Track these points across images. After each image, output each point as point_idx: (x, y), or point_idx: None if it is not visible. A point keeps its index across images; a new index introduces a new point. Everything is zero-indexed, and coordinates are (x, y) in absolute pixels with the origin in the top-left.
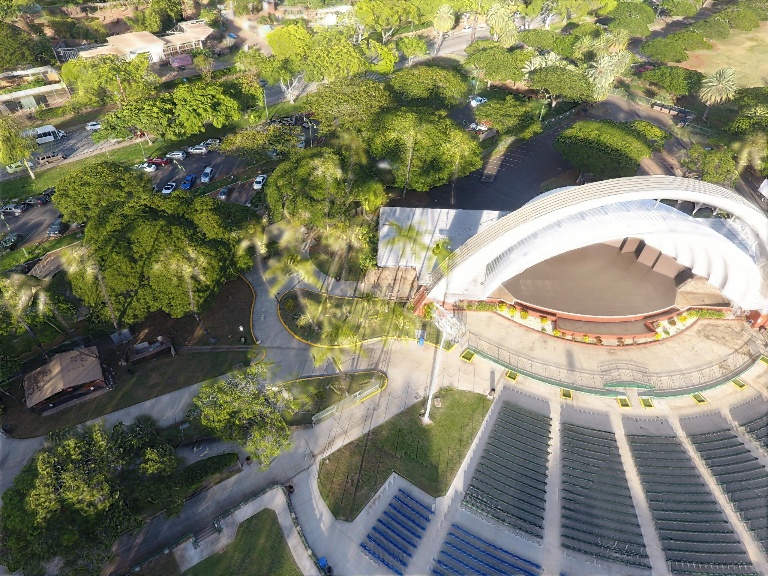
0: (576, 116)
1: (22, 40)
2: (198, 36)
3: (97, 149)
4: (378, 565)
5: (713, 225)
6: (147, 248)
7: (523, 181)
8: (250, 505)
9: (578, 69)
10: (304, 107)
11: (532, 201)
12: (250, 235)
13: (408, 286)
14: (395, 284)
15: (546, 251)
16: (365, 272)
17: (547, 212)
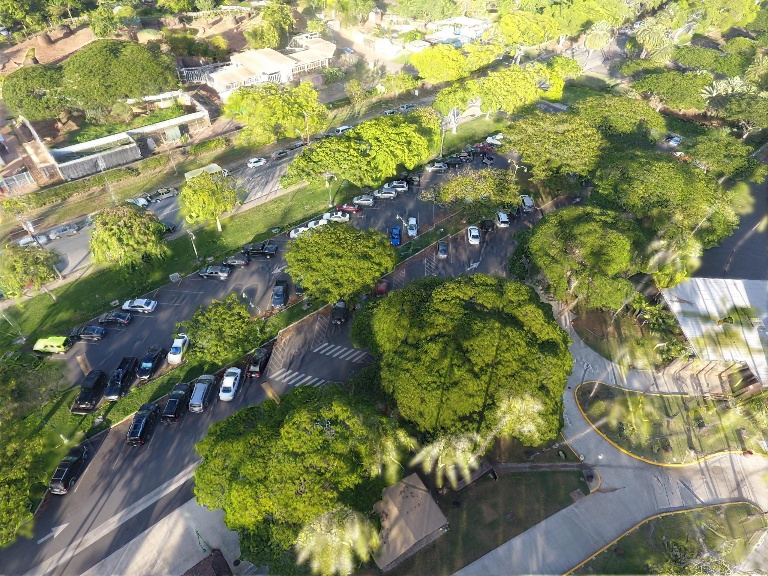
0: None
1: (164, 64)
2: (325, 53)
3: (272, 192)
4: None
5: None
6: (487, 358)
7: (759, 232)
8: None
9: None
10: (504, 146)
11: None
12: None
13: (716, 378)
14: (698, 375)
15: None
16: (667, 362)
17: None
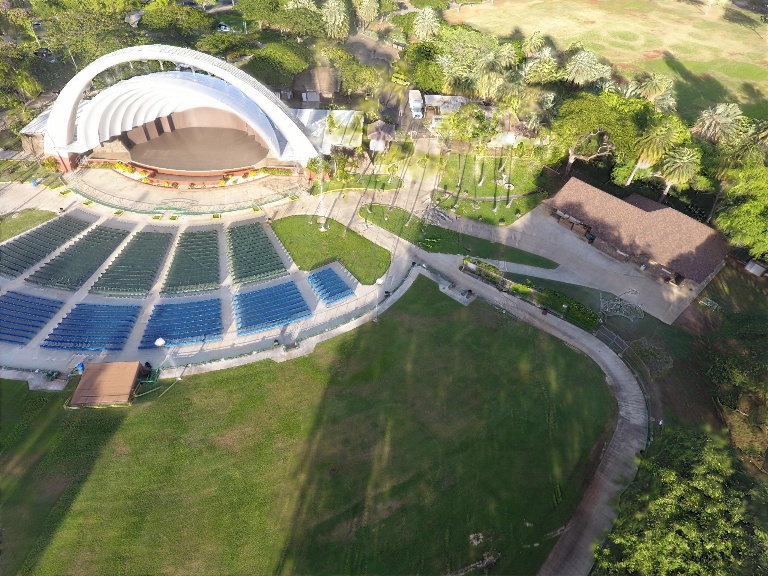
0: None
1: None
2: None
3: None
4: None
5: (317, 113)
6: None
7: None
8: None
9: None
10: None
11: None
12: None
13: None
14: None
15: None
16: None
17: None
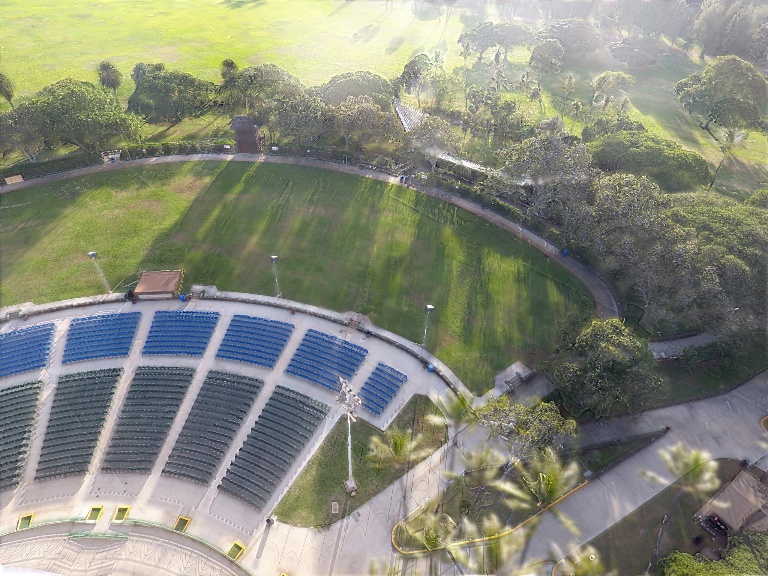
0: None
1: None
2: None
3: None
4: None
5: None
6: None
7: None
8: None
9: None
10: None
11: None
12: None
13: None
14: None
15: None
16: None
17: None
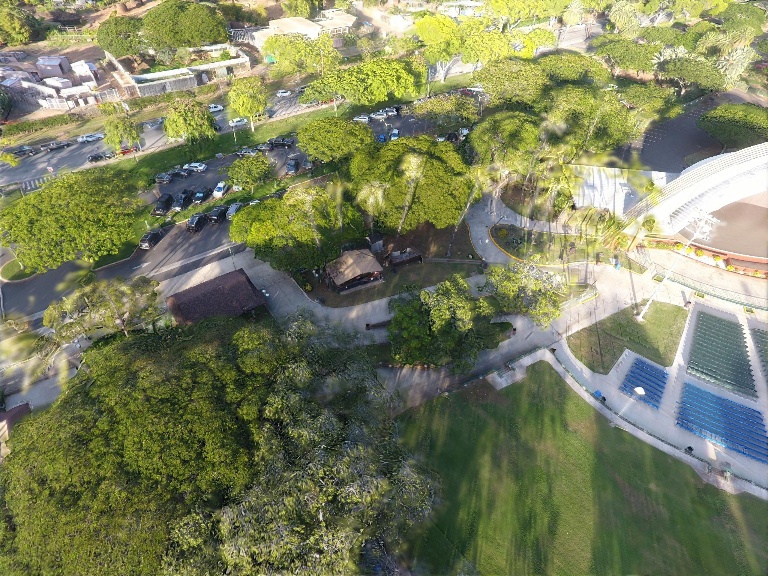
0: (703, 104)
1: (218, 19)
2: (346, 22)
3: (293, 112)
4: (637, 401)
5: None
6: (417, 174)
7: (668, 154)
8: (529, 357)
9: (707, 61)
10: (472, 83)
11: (702, 163)
12: None
13: (594, 227)
14: (582, 225)
15: (744, 191)
16: (559, 213)
17: (752, 158)
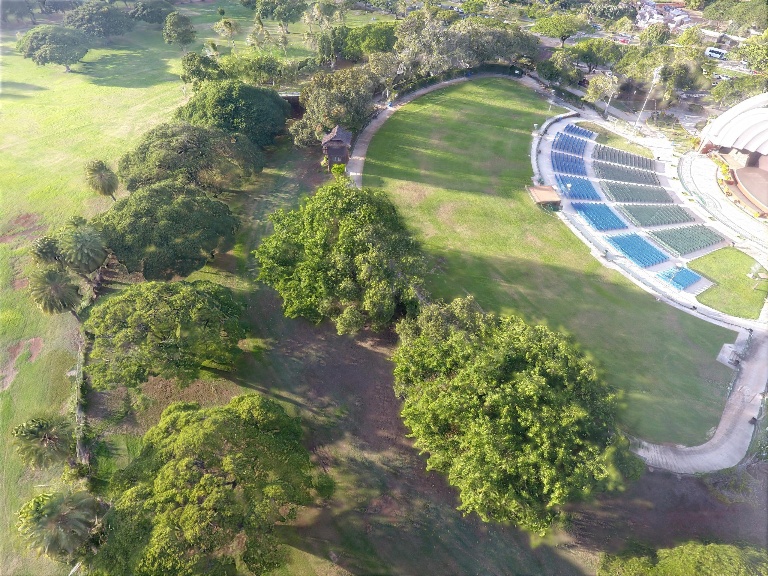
0: None
1: None
2: None
3: (726, 67)
4: None
5: None
6: None
7: None
8: (569, 108)
9: None
10: None
11: None
12: (691, 85)
13: None
14: None
15: None
16: None
17: None
